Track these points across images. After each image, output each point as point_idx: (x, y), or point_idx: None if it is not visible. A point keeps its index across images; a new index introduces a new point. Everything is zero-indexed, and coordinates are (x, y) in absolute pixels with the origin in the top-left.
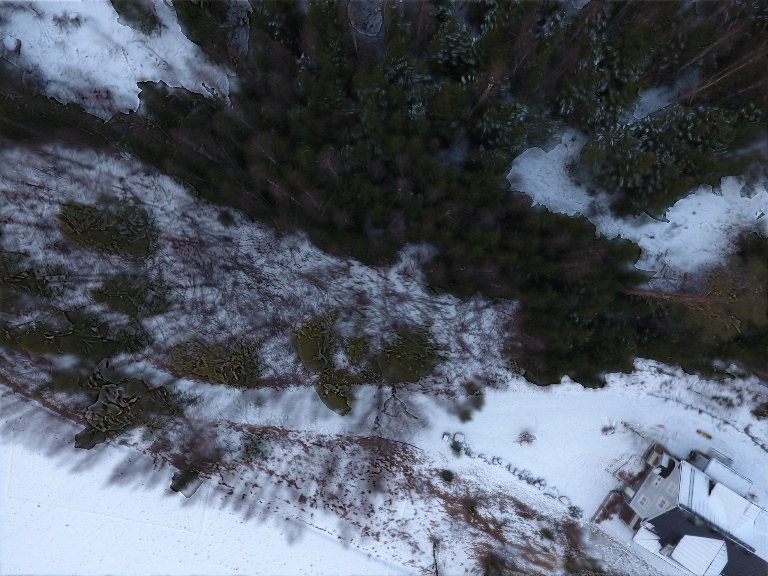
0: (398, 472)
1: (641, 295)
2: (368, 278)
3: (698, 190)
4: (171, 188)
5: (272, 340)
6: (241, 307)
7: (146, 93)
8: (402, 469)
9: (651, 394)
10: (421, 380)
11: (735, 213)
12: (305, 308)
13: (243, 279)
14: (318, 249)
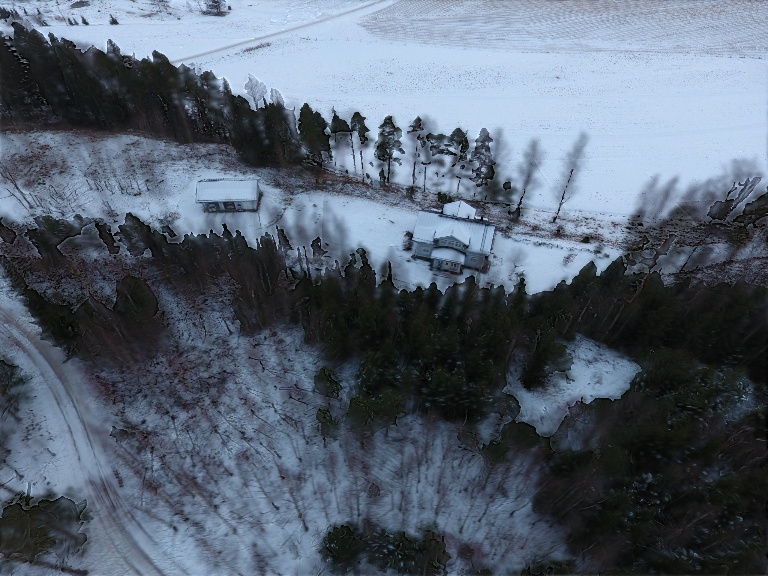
0: None
1: None
2: None
3: None
4: None
5: None
6: None
7: None
8: None
9: None
10: None
11: (562, 404)
12: None
13: None
14: None
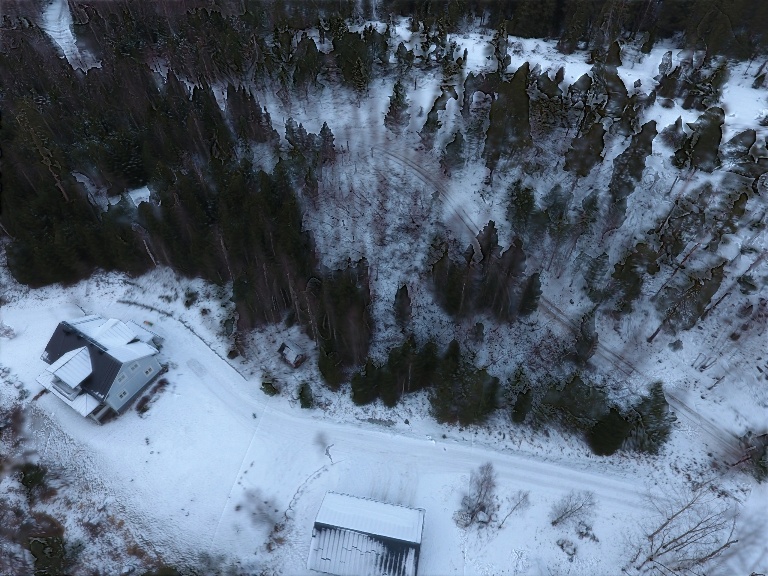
0: None
1: (60, 188)
2: None
3: None
4: None
5: None
6: None
7: None
8: None
9: (119, 301)
10: None
11: None
12: None
13: None
14: None
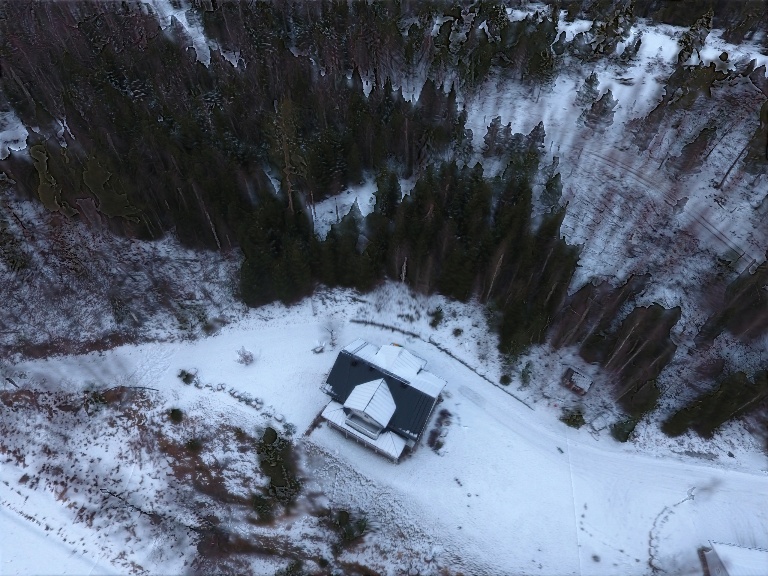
0: (133, 427)
1: (289, 198)
2: (143, 250)
3: (357, 190)
4: (28, 208)
5: (57, 307)
6: (43, 282)
7: (30, 134)
8: (137, 421)
9: (353, 321)
10: (170, 328)
11: None
12: (92, 277)
13: (52, 260)
14: (113, 234)
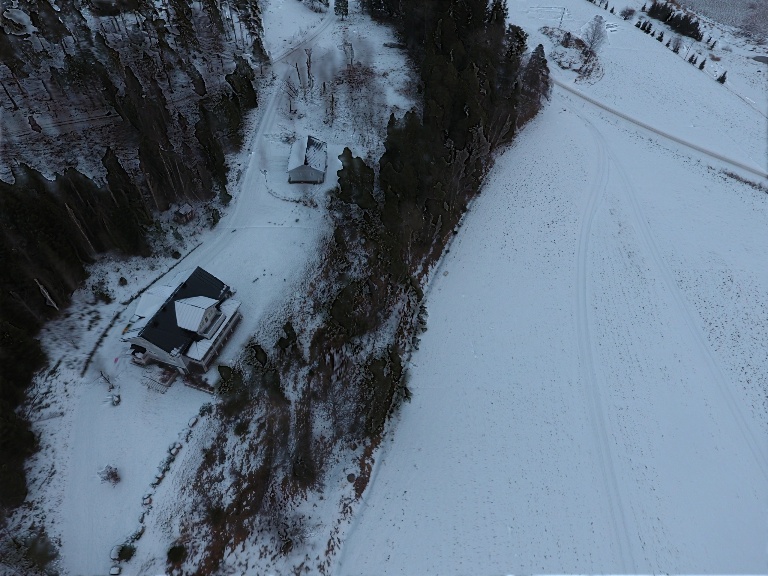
0: None
1: None
2: None
3: None
4: None
5: None
6: None
7: None
8: None
9: (82, 374)
10: None
11: None
12: None
13: None
14: None
